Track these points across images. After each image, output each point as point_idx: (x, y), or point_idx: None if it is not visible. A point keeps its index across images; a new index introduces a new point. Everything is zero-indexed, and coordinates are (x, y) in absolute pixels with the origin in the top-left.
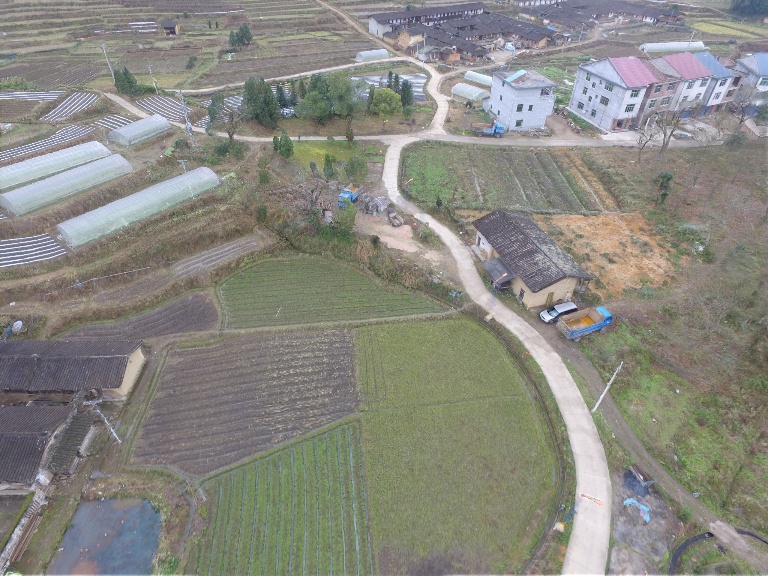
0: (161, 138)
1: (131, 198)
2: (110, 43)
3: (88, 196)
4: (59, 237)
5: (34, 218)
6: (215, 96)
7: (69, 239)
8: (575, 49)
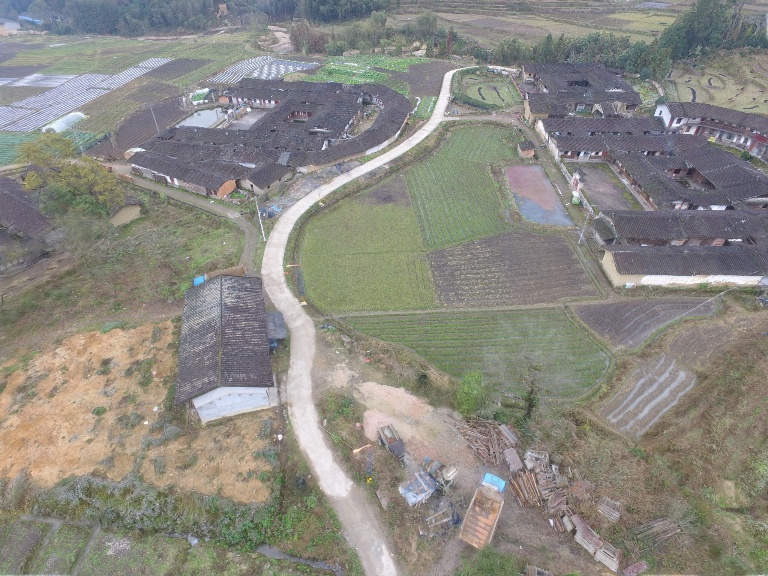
0: None
1: None
2: None
3: None
4: None
5: None
6: None
7: None
8: None
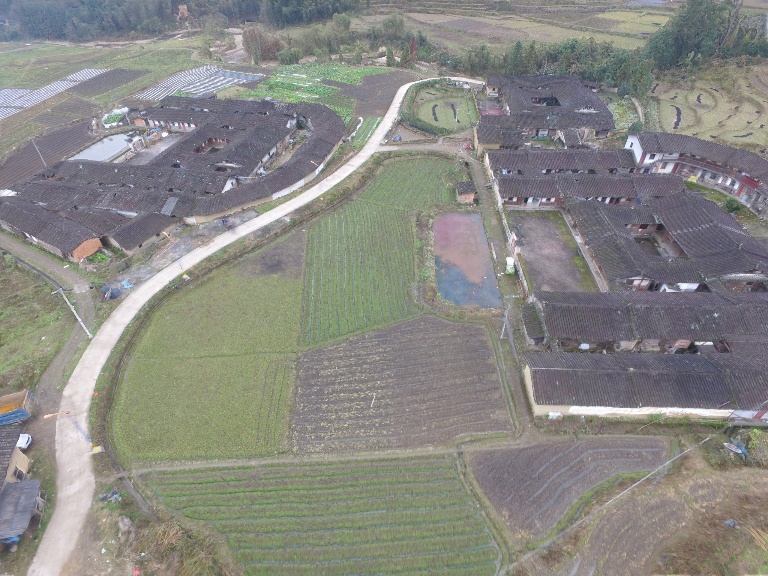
0: None
1: None
2: None
3: None
4: None
5: None
6: None
7: None
8: None
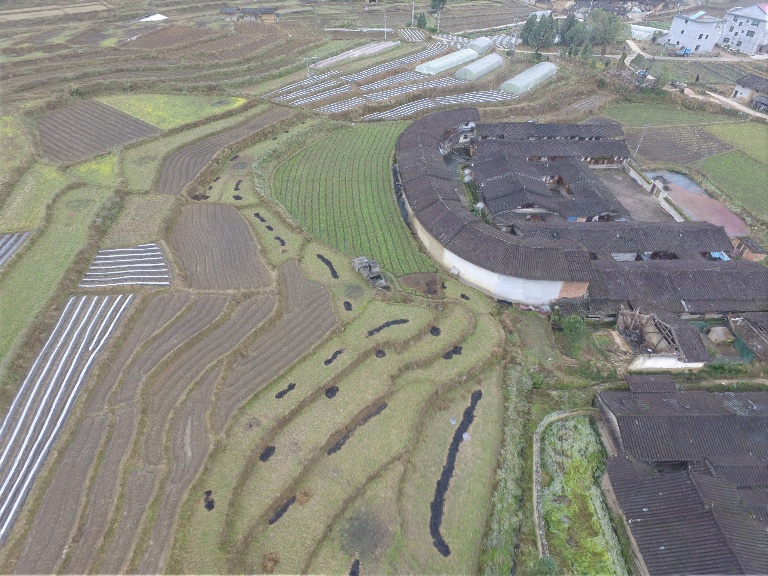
0: (492, 51)
1: (528, 73)
2: (335, 7)
3: (497, 74)
4: (503, 91)
5: (486, 81)
6: (544, 19)
7: (516, 90)
8: (684, 12)
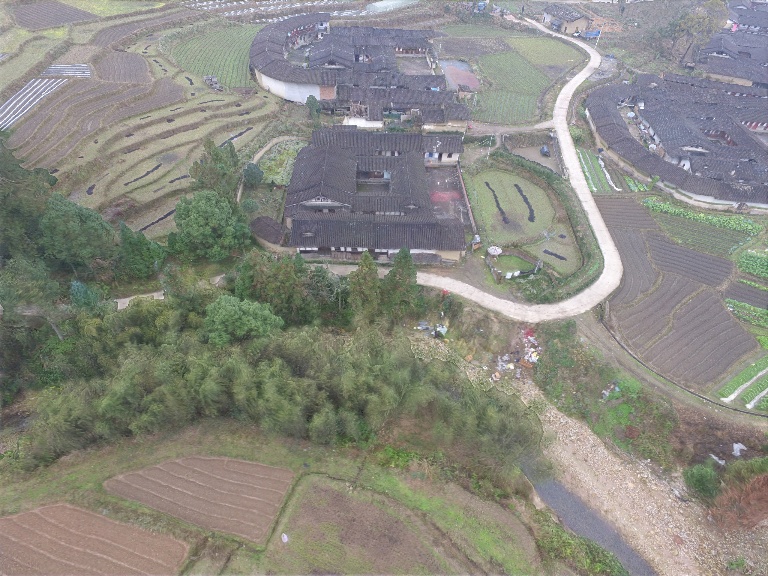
0: None
1: None
2: None
3: None
4: (368, 11)
5: (356, 3)
6: None
7: (376, 9)
8: None
